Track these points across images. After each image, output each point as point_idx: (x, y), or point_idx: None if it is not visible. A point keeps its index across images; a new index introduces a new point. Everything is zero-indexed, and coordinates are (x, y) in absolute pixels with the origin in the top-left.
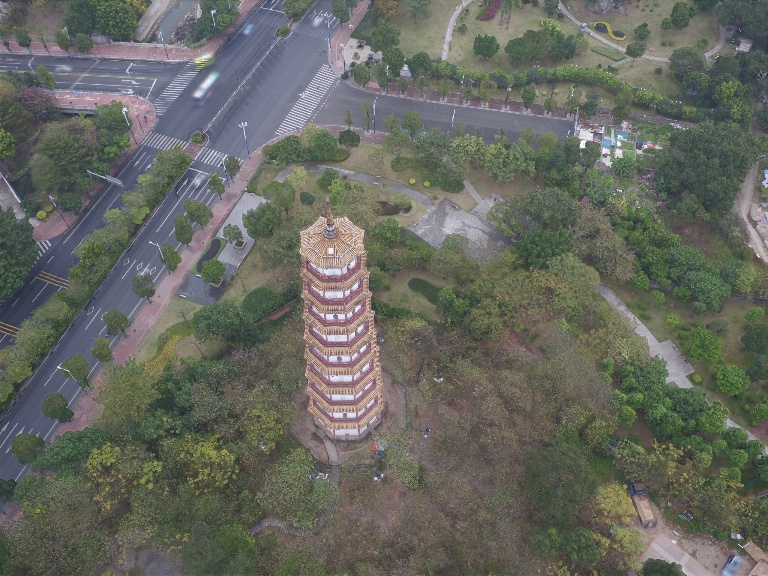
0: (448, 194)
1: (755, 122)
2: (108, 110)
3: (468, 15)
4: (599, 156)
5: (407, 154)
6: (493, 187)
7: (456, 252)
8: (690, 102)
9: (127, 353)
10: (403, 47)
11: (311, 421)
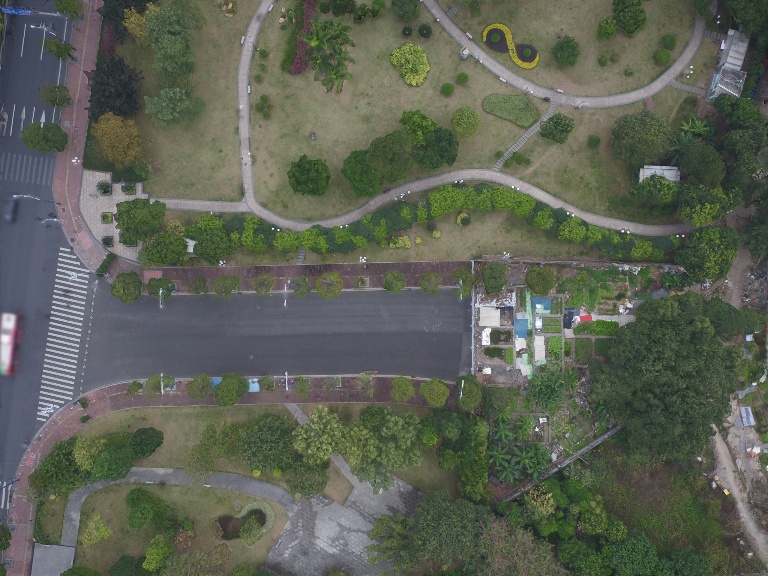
0: None
1: (740, 220)
2: None
3: (266, 59)
4: None
5: (237, 416)
6: None
7: None
8: (643, 211)
9: None
10: (175, 176)
11: None
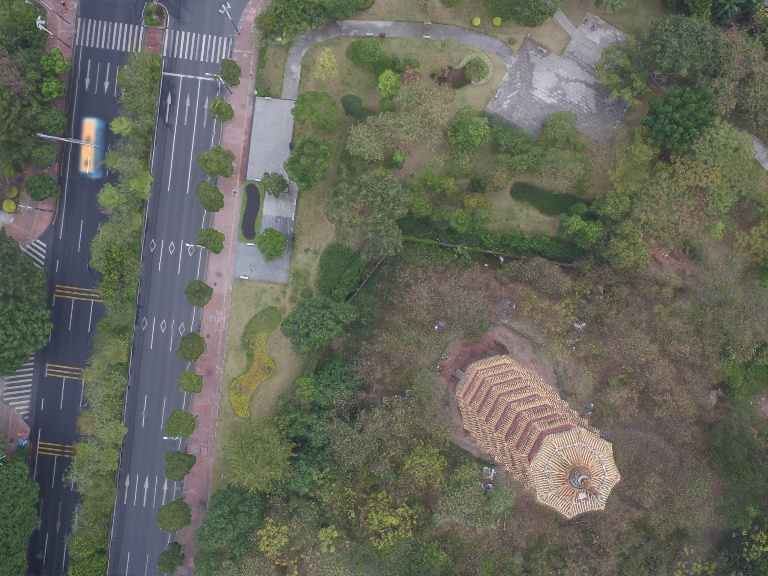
0: (528, 30)
1: None
2: (7, 13)
3: None
4: None
5: None
6: (587, 2)
7: (566, 141)
8: None
9: (213, 366)
10: None
11: (458, 416)
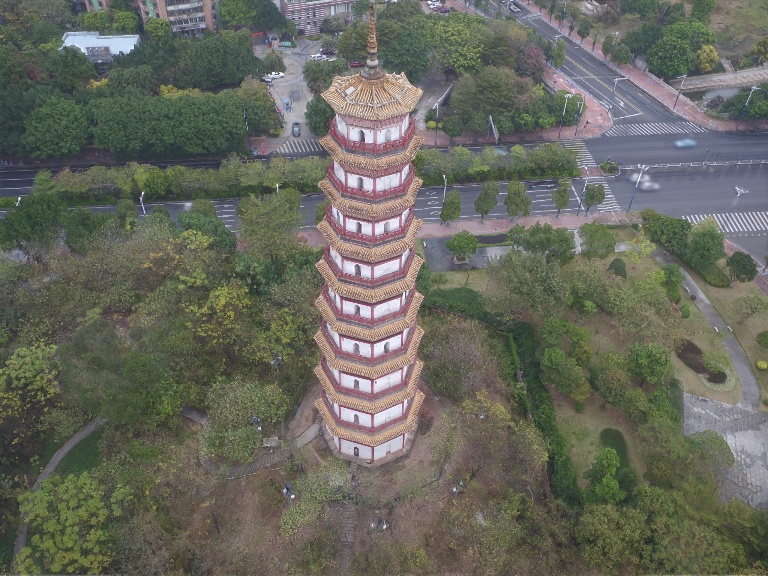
0: None
1: None
2: None
3: None
4: None
5: None
6: None
7: None
8: None
9: None
10: None
11: None
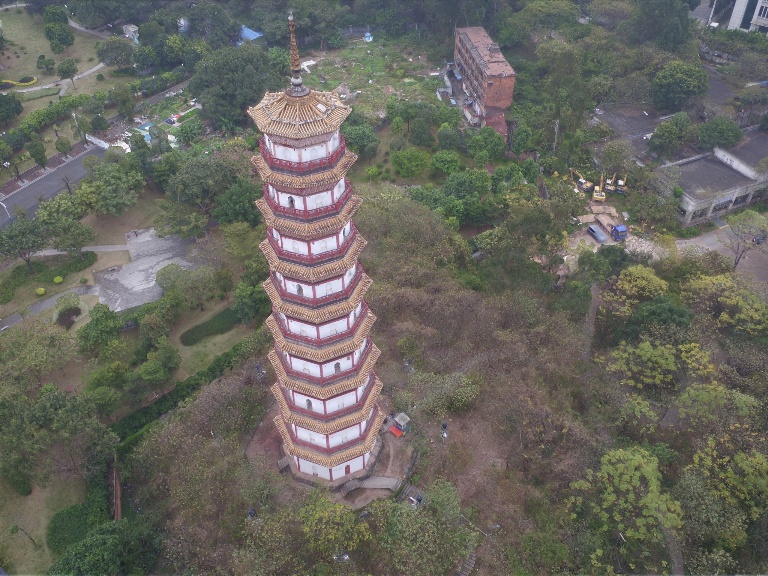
0: (90, 269)
1: None
2: None
3: None
4: (167, 136)
5: None
6: (118, 230)
7: None
8: None
9: None
10: None
11: None
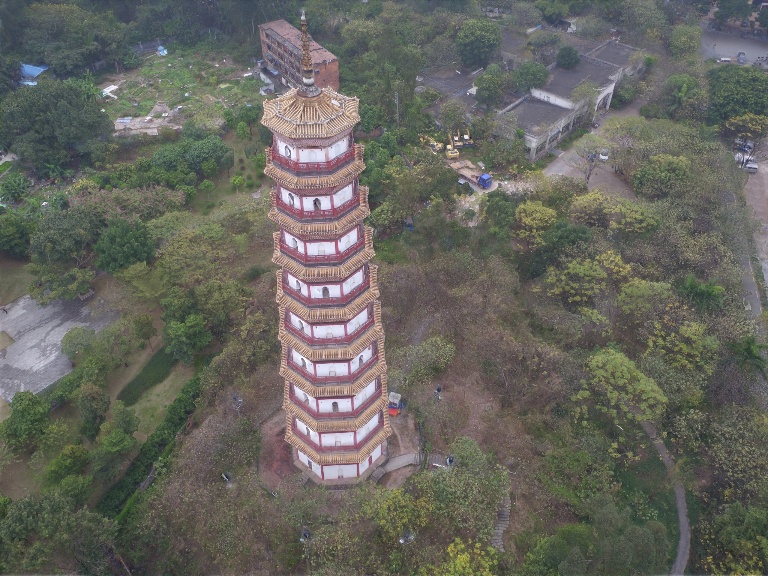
0: None
1: None
2: None
3: None
4: None
5: None
6: None
7: None
8: None
9: None
10: None
11: None
